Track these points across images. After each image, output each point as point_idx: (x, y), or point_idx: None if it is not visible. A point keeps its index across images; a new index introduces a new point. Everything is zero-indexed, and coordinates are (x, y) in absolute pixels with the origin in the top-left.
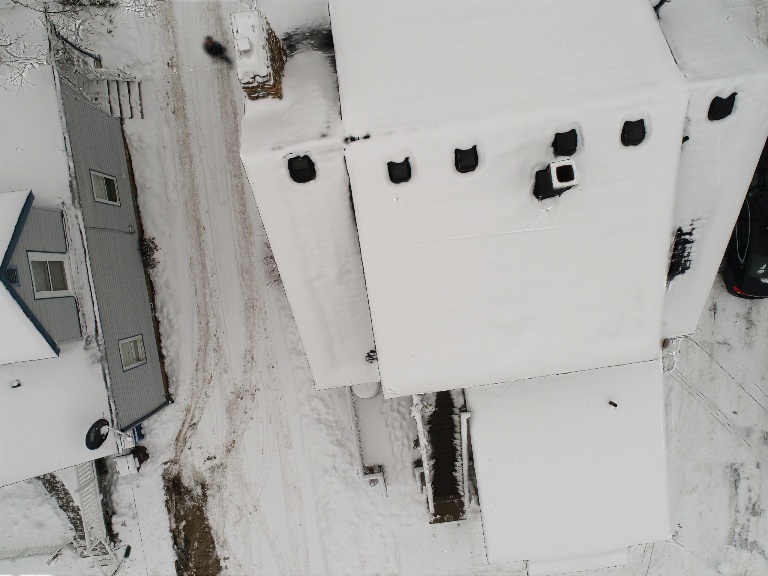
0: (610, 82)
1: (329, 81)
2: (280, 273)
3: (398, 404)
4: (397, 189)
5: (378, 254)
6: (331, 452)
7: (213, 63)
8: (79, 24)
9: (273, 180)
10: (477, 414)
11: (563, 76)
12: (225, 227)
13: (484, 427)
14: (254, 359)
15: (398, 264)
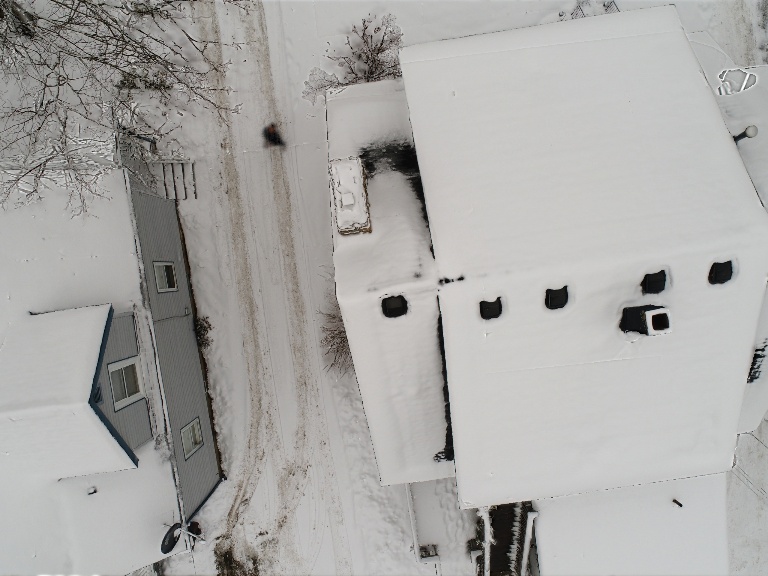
0: (699, 225)
1: (414, 209)
2: (362, 392)
3: (452, 485)
4: (487, 325)
5: (465, 383)
6: (383, 529)
7: (266, 144)
8: (134, 107)
9: (367, 318)
10: (543, 512)
11: (652, 218)
12: (278, 306)
13: (549, 525)
14: (306, 436)
15: (484, 391)
